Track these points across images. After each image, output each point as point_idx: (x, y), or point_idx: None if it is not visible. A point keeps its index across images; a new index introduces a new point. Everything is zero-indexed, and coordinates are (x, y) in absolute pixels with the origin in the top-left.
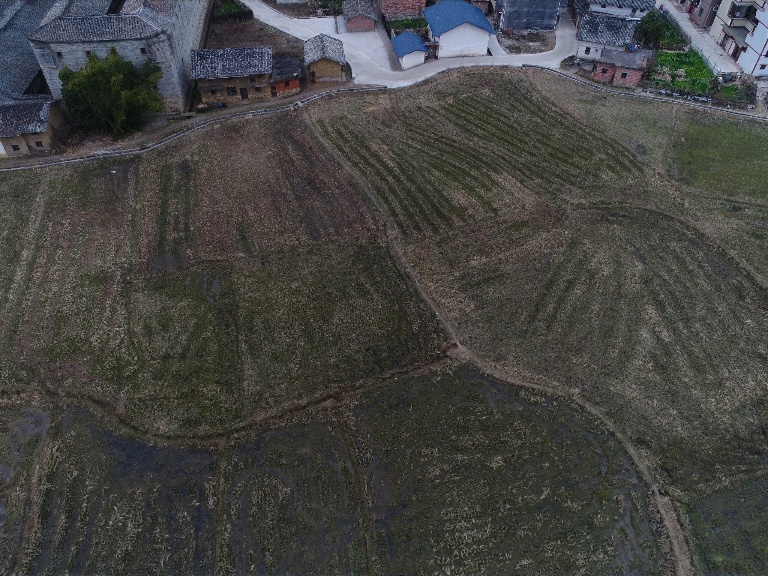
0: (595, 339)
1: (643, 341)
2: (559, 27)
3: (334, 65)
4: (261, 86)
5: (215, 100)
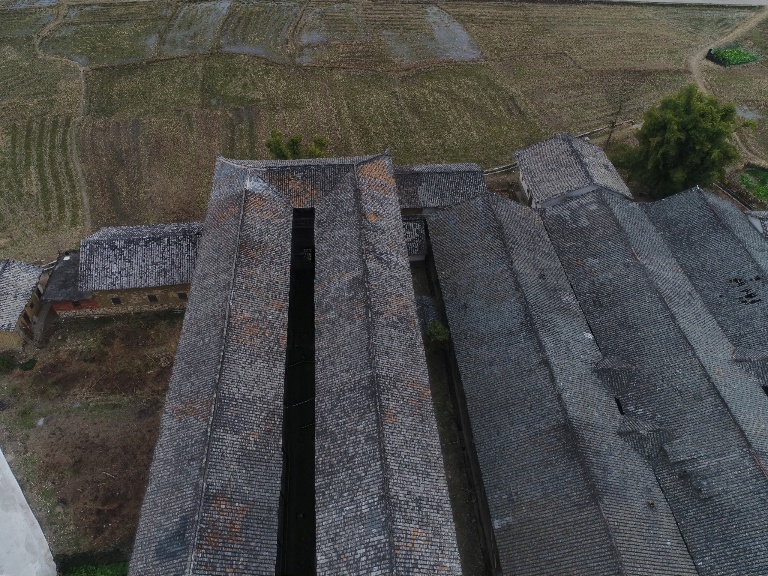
0: (5, 71)
1: None
2: None
3: None
4: None
5: None
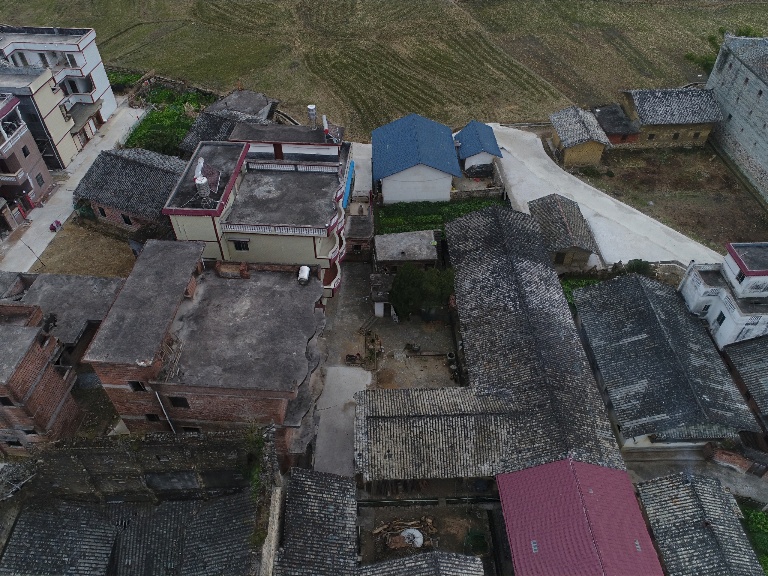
0: (391, 1)
1: (370, 0)
2: None
3: None
4: None
5: None
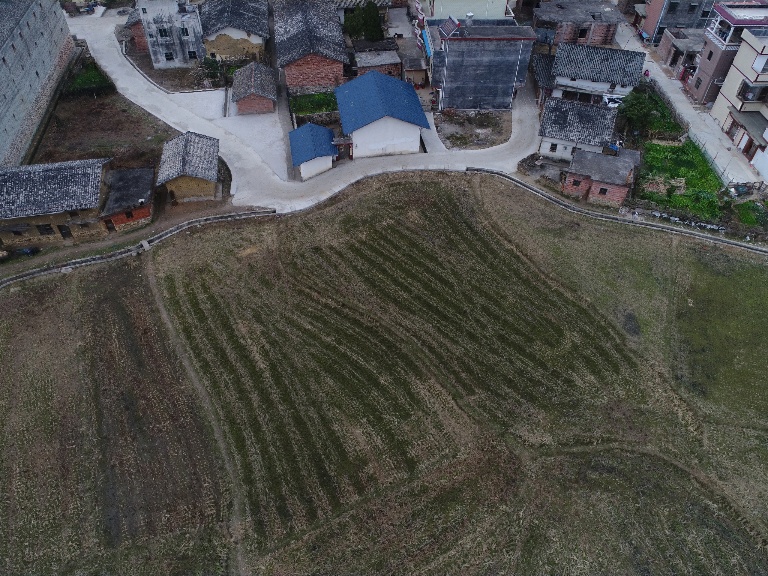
0: None
1: None
2: (517, 104)
3: (200, 182)
4: (87, 222)
5: (23, 241)
